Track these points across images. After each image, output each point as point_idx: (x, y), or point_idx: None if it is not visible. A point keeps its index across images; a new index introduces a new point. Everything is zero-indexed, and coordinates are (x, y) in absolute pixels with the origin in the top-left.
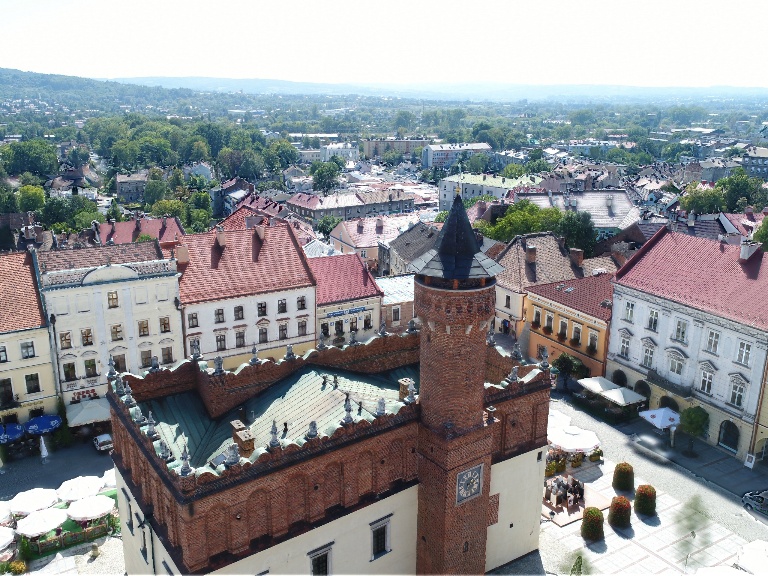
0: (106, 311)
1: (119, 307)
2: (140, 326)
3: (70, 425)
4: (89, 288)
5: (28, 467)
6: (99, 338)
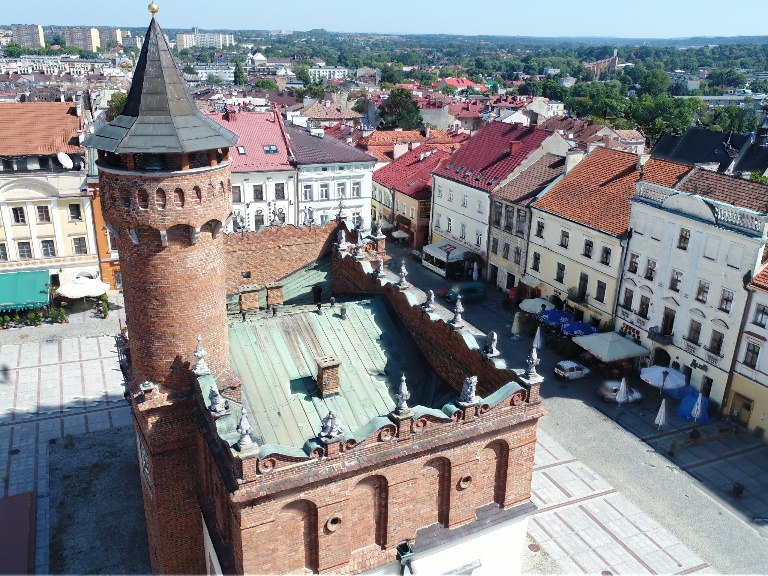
0: (674, 249)
1: (687, 251)
2: (702, 287)
3: (574, 339)
4: (666, 214)
5: (525, 347)
6: (660, 277)
